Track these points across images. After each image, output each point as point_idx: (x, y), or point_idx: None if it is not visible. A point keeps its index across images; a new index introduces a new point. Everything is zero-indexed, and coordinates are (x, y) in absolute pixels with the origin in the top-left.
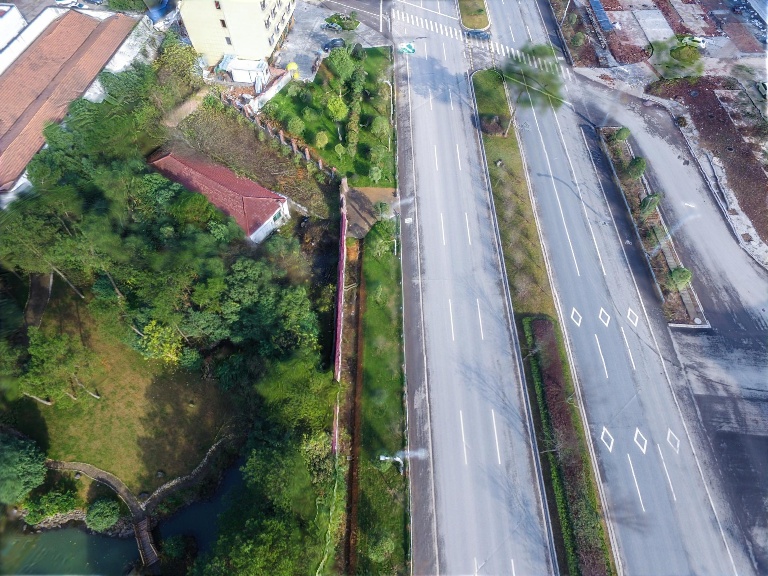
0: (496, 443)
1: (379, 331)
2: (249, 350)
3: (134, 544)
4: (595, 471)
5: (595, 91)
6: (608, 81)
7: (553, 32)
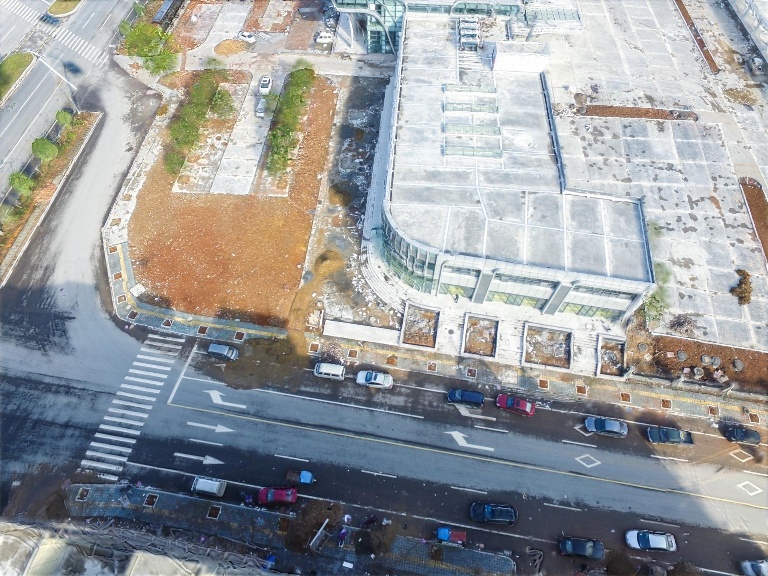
0: None
1: None
2: None
3: None
4: None
5: (112, 78)
6: (134, 69)
7: (131, 21)
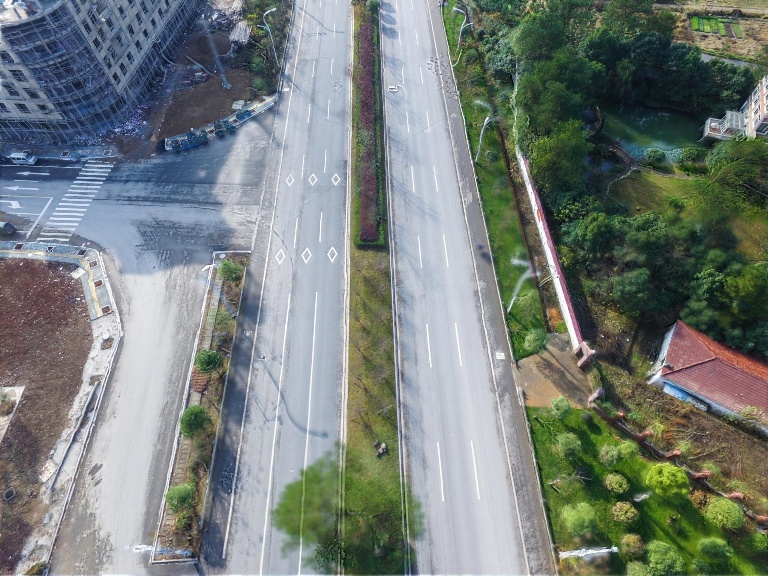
0: (413, 175)
1: (509, 240)
2: (614, 213)
3: (626, 149)
4: (350, 164)
5: None
6: None
7: None
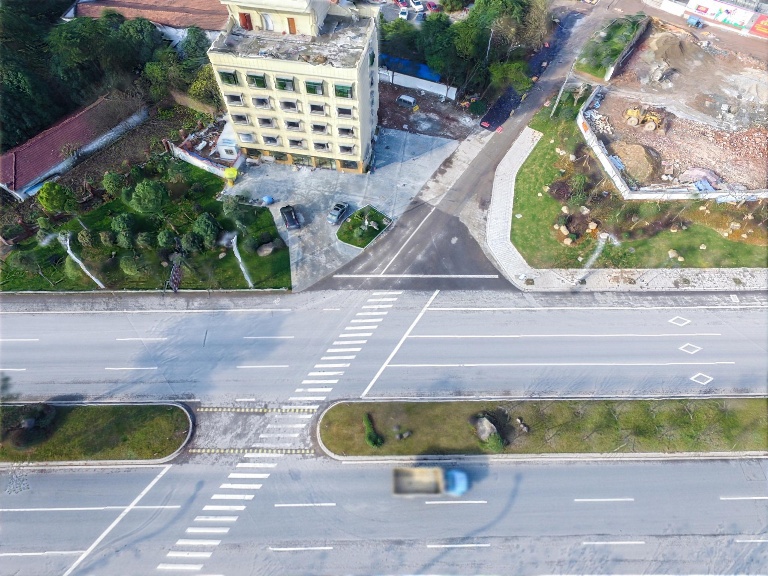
0: None
1: None
2: None
3: None
4: None
5: None
6: None
7: None
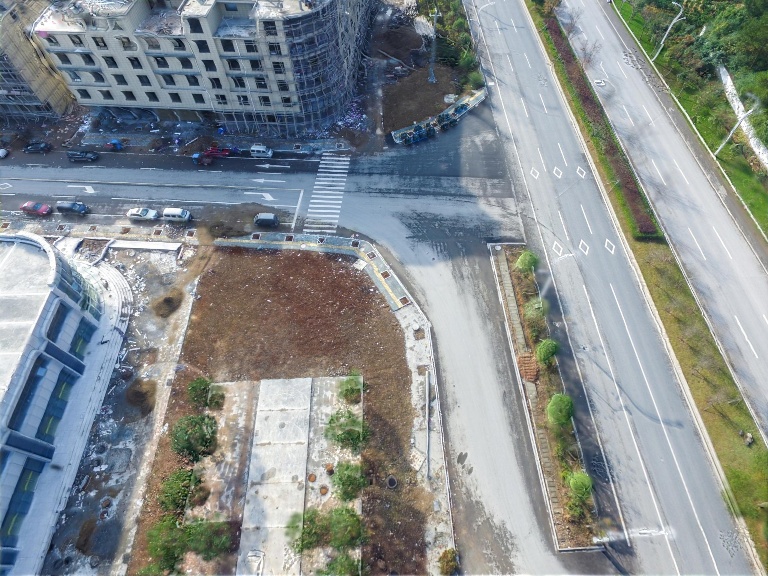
0: (658, 169)
1: None
2: None
3: None
4: (589, 157)
5: None
6: None
7: None
